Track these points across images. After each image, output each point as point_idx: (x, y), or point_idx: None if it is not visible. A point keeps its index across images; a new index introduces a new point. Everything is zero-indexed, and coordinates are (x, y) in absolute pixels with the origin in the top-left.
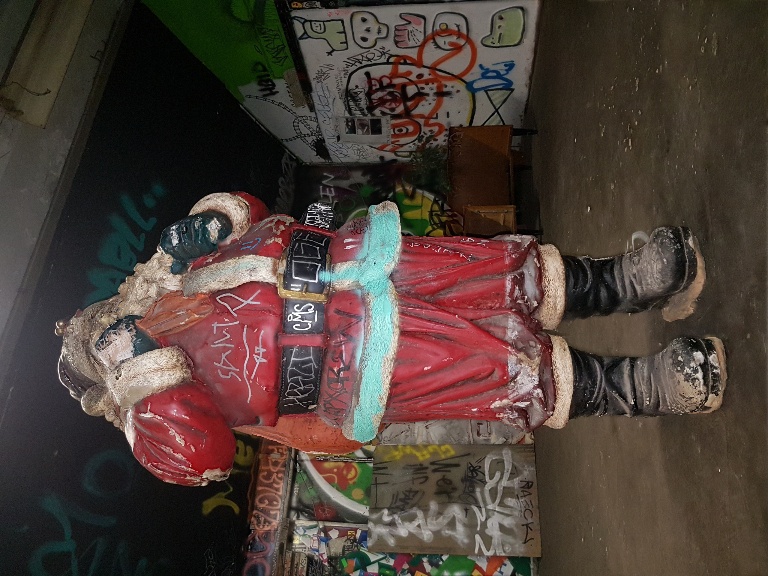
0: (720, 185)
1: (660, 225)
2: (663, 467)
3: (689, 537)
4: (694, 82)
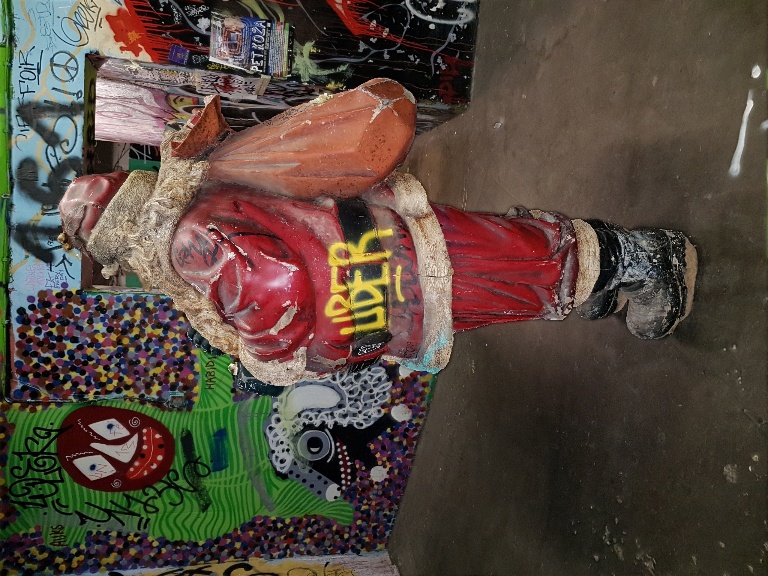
0: (675, 385)
1: (766, 229)
2: (614, 142)
3: (578, 179)
4: (767, 419)
